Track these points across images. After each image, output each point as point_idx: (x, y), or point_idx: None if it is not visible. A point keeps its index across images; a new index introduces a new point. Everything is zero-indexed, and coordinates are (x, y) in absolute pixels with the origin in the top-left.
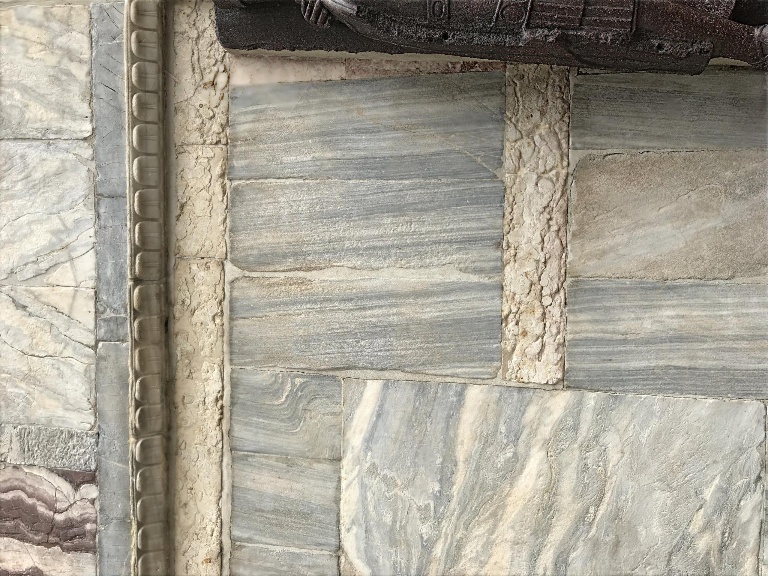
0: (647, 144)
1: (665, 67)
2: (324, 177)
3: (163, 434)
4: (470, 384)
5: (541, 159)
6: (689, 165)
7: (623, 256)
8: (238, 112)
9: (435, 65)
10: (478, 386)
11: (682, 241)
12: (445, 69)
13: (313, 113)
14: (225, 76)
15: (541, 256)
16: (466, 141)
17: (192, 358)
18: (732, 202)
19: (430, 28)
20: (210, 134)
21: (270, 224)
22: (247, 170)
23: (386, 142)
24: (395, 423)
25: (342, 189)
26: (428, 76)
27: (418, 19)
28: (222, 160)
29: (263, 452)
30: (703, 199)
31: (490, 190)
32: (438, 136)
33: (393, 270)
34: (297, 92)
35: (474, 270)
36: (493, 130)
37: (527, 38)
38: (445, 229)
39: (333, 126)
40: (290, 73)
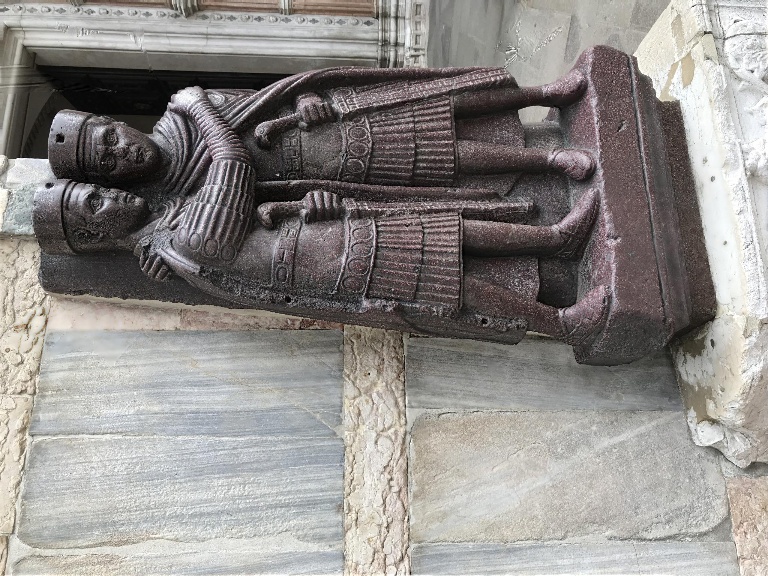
0: (476, 404)
1: (488, 337)
2: (148, 433)
3: None
4: None
5: (380, 417)
6: (515, 425)
7: (464, 518)
8: (53, 359)
9: (274, 321)
10: None
11: (517, 501)
12: (284, 325)
13: (141, 363)
14: (42, 320)
15: (383, 520)
16: (305, 397)
17: None
18: (556, 461)
19: (273, 291)
20: (14, 382)
21: (76, 488)
22: (55, 424)
23: (220, 396)
24: None
25: (168, 447)
26: (267, 331)
27: (262, 282)
28: (25, 412)
29: None
30: (530, 458)
31: (329, 448)
32: (276, 391)
33: (222, 541)
34: (125, 340)
35: (313, 538)
36: (332, 387)
37: (367, 307)
38: (282, 492)
39: (163, 378)
40: (119, 320)
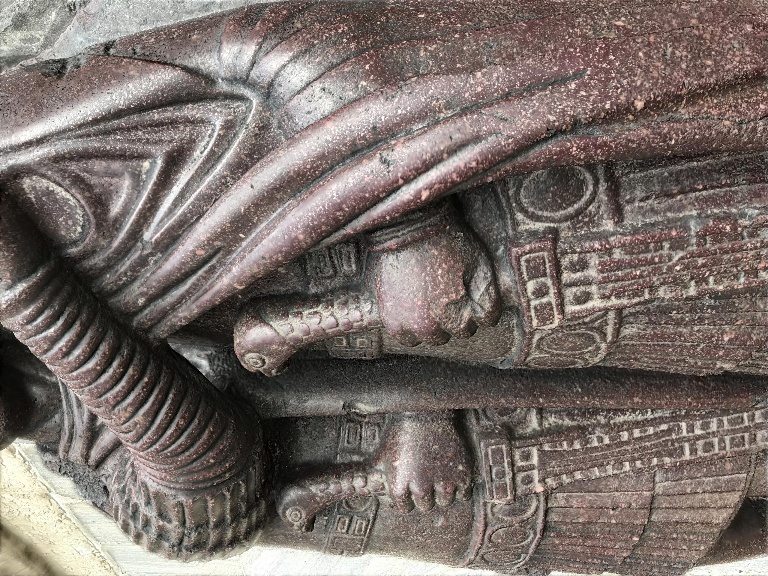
0: None
1: None
2: None
3: (43, 574)
4: (375, 557)
5: None
6: None
7: None
8: None
9: None
10: (384, 558)
11: None
12: None
13: None
14: None
15: None
16: None
17: (47, 536)
18: None
19: None
20: None
21: None
22: None
23: None
24: (297, 567)
25: None
26: None
27: None
28: None
29: (161, 573)
30: None
31: None
32: None
33: None
34: None
35: None
36: None
37: None
38: None
39: None
40: None
